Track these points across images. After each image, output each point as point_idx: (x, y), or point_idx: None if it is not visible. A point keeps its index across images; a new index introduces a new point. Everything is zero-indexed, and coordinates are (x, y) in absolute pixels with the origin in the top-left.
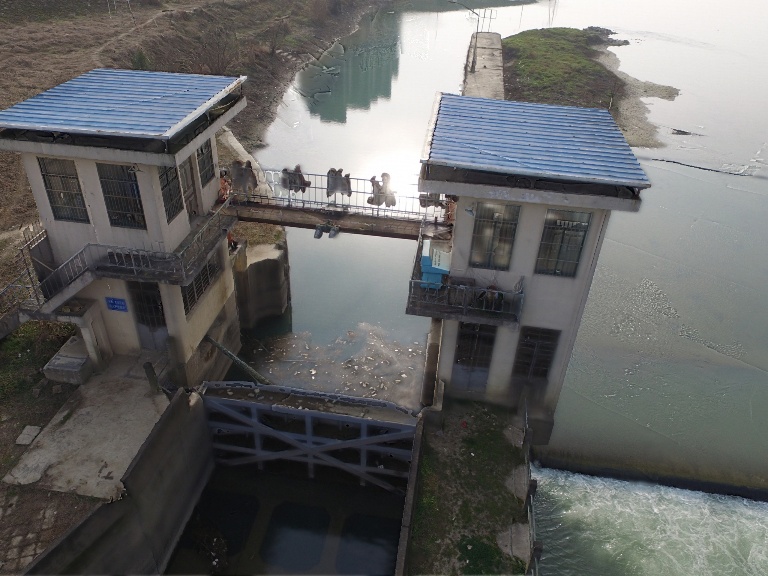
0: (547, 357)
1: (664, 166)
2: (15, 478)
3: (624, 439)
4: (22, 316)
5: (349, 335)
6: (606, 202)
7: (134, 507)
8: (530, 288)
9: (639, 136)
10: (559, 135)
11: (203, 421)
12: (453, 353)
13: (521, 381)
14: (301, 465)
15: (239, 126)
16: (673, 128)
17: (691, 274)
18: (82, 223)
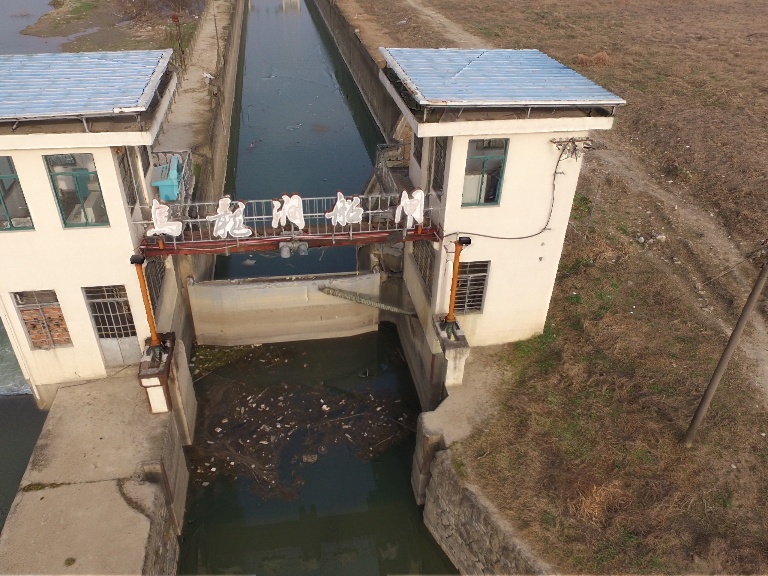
0: None
1: None
2: None
3: None
4: None
5: (303, 467)
6: None
7: None
8: None
9: None
10: (15, 80)
11: None
12: None
13: None
14: None
15: None
16: None
17: None
18: None
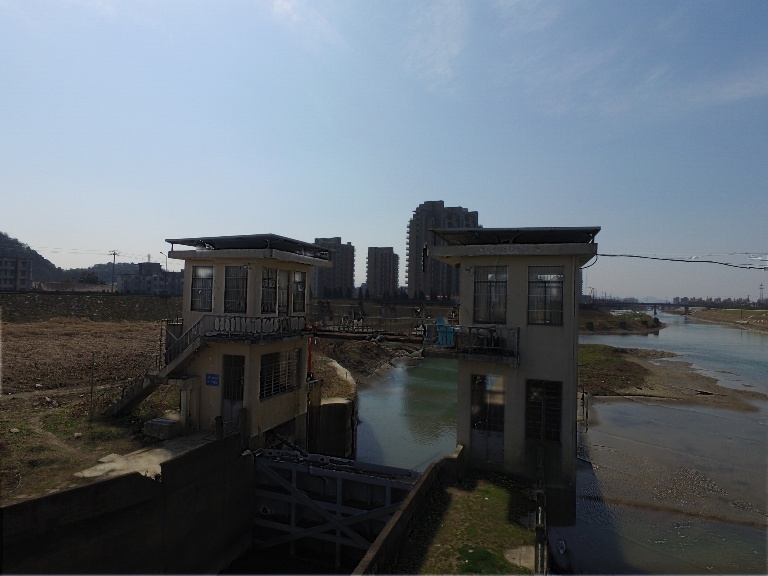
0: (556, 416)
1: (692, 410)
2: (82, 474)
3: (680, 575)
4: (145, 381)
5: (397, 472)
6: (569, 247)
7: (162, 498)
8: (526, 339)
9: (665, 393)
10: None
11: (250, 482)
12: (469, 413)
13: (535, 444)
14: (330, 555)
15: None
16: (695, 390)
17: (733, 468)
18: (206, 312)
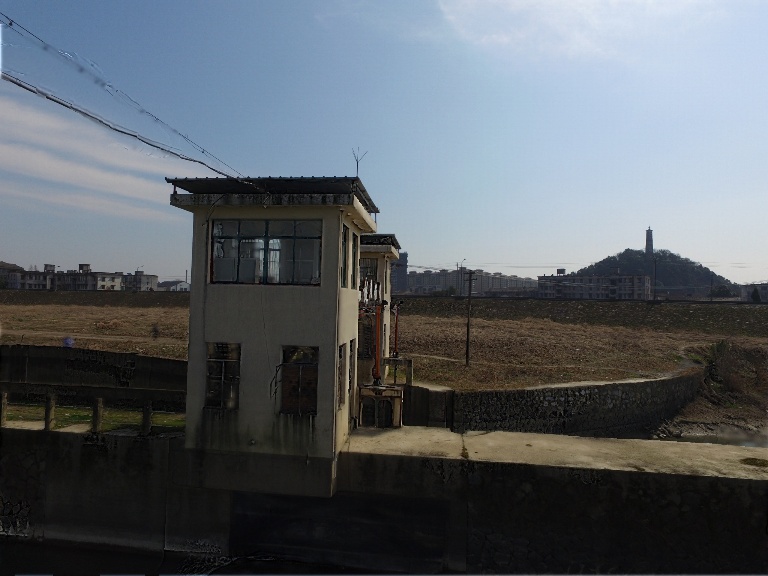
0: None
1: None
2: None
3: None
4: None
5: None
6: None
7: None
8: None
9: None
10: None
11: None
12: None
13: None
14: None
15: (759, 413)
16: None
17: None
18: None
